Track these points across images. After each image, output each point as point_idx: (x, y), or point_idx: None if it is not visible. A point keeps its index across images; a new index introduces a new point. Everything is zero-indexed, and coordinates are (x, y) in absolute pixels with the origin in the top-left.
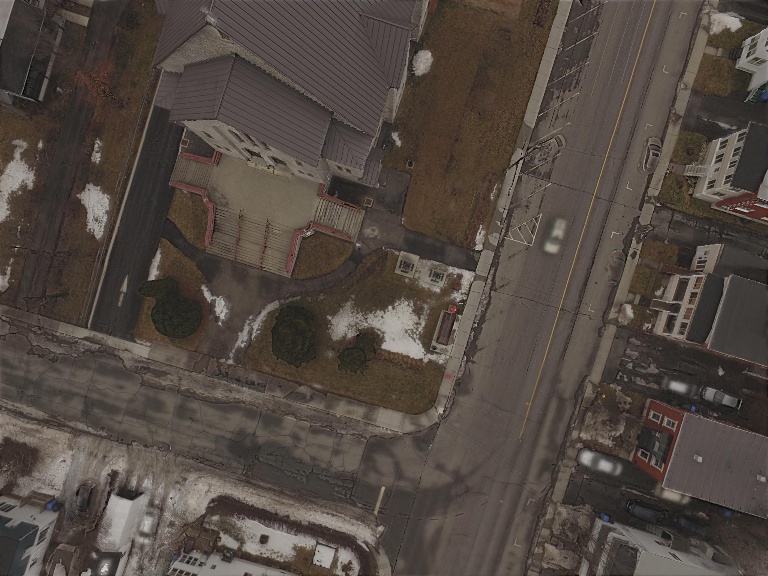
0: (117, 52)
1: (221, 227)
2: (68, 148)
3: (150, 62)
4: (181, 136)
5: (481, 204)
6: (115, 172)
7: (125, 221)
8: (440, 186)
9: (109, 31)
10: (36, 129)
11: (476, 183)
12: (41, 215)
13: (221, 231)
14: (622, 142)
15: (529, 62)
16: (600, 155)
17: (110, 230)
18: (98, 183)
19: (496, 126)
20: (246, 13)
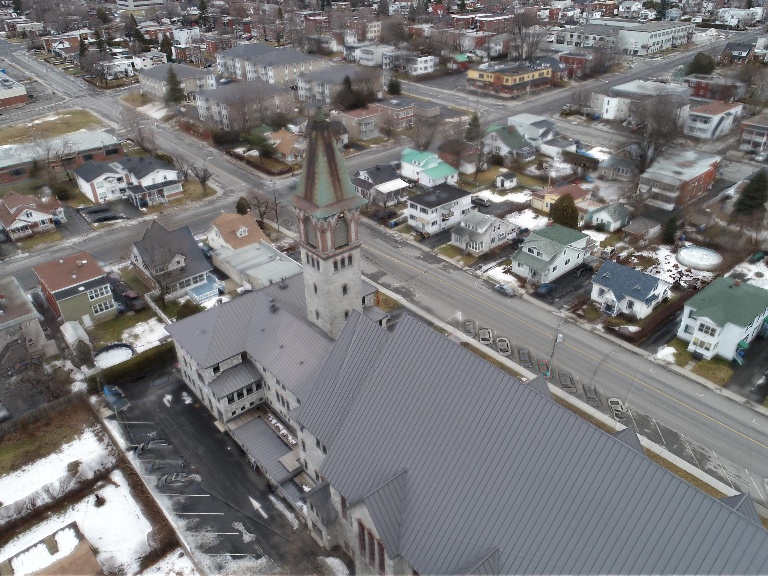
0: None
1: None
2: None
3: None
4: None
5: None
6: None
7: None
8: None
9: None
10: None
11: None
12: None
13: None
14: None
15: None
16: None
17: None
18: None
19: None
20: None
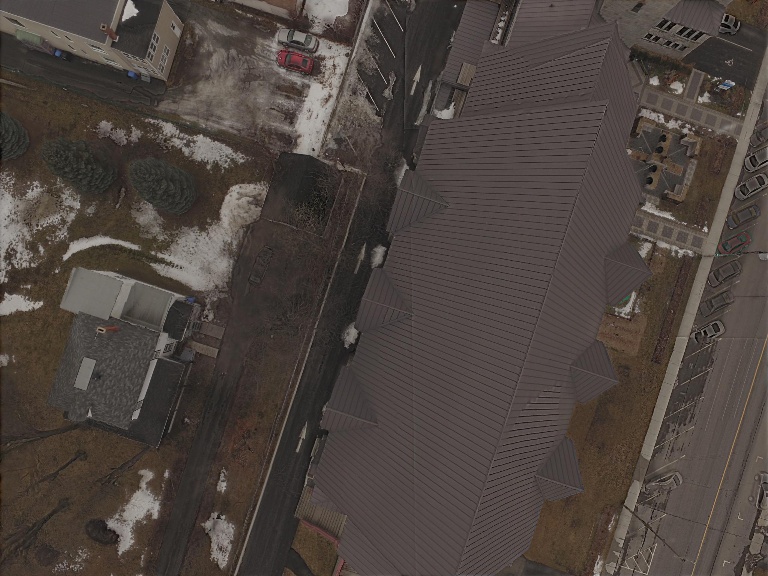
0: (245, 383)
1: (349, 567)
2: (194, 478)
3: (278, 394)
4: (307, 467)
5: (600, 536)
6: (240, 502)
7: (249, 551)
8: (560, 518)
9: (238, 362)
10: (163, 459)
11: (595, 515)
12: (165, 544)
13: (348, 570)
14: (734, 474)
15: (647, 397)
16: (713, 487)
17: (235, 561)
18: (223, 512)
19: (615, 459)
20: (466, 575)
